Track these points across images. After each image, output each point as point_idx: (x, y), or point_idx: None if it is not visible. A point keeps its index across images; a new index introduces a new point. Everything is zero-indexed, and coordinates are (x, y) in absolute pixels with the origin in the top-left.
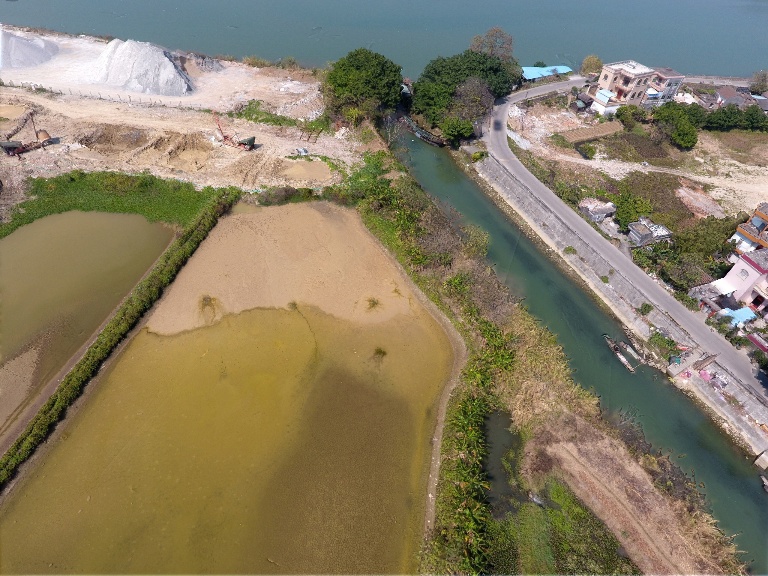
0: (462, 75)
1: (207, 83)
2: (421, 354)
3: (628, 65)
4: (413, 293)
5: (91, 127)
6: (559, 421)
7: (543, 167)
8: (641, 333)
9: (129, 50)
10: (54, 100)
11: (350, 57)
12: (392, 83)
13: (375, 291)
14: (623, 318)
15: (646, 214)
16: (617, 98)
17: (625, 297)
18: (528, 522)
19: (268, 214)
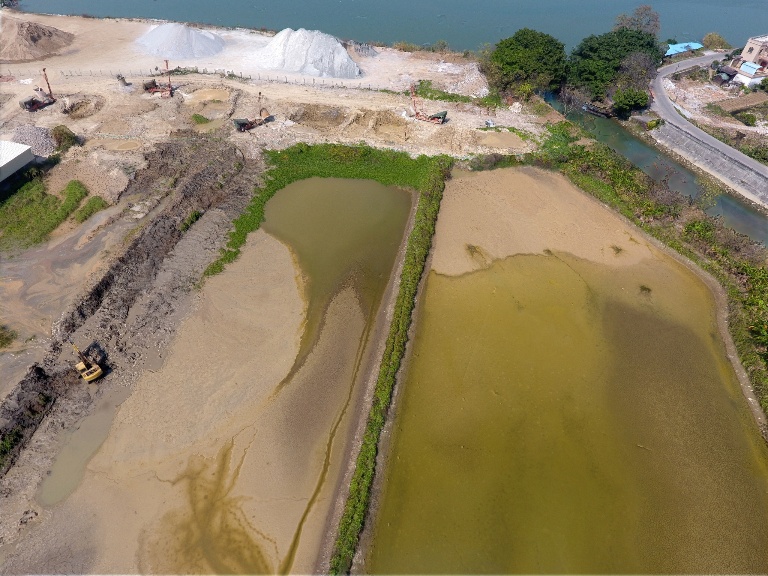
0: (622, 51)
1: (370, 67)
2: (682, 290)
3: None
4: (648, 241)
5: (294, 106)
6: None
7: None
8: None
9: (302, 38)
10: (247, 84)
11: (518, 37)
12: (559, 60)
13: (614, 240)
14: None
15: None
16: (760, 70)
17: None
18: None
19: (485, 177)
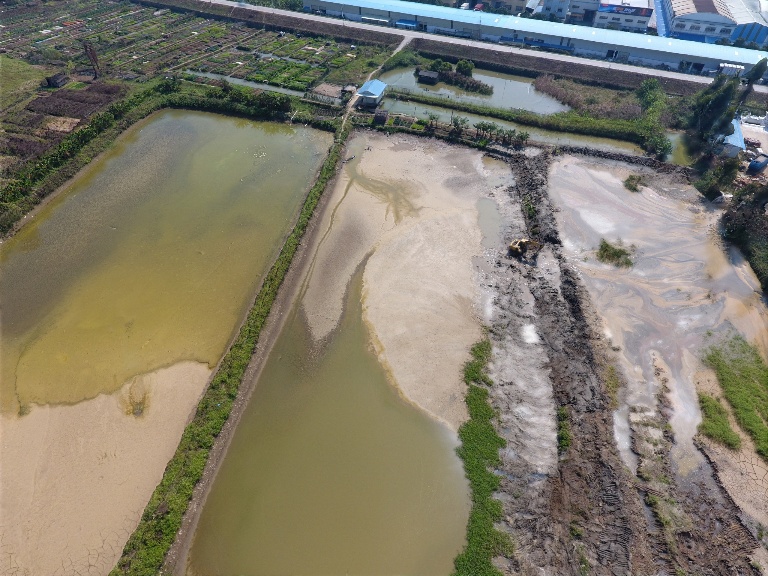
0: None
1: None
2: None
3: None
4: None
5: None
6: None
7: None
8: None
9: None
10: None
11: None
12: None
13: None
14: None
15: None
16: None
17: None
18: None
19: None
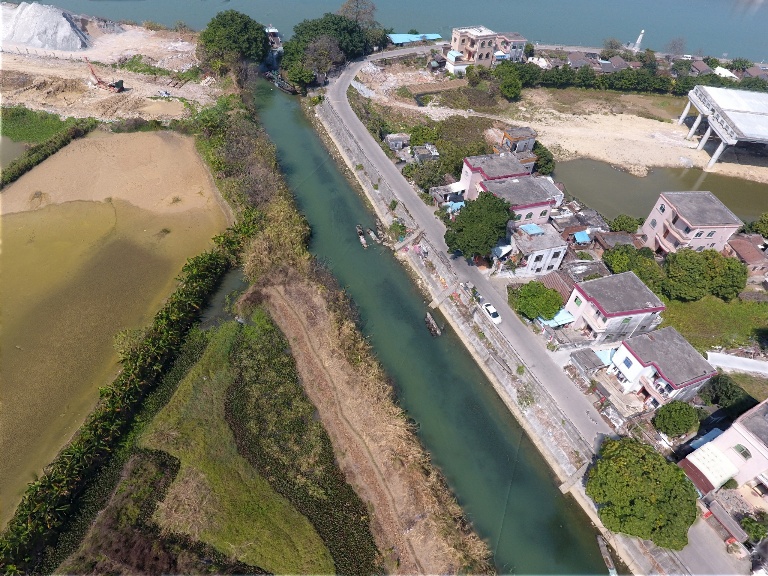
0: (318, 34)
1: (104, 42)
2: (199, 233)
3: (476, 29)
4: (214, 194)
5: None
6: (277, 271)
7: (376, 111)
8: (387, 223)
9: (33, 11)
10: None
11: (218, 17)
12: (254, 39)
13: (182, 192)
14: (380, 214)
15: (432, 141)
16: (468, 59)
17: (385, 199)
18: (222, 330)
19: (116, 138)
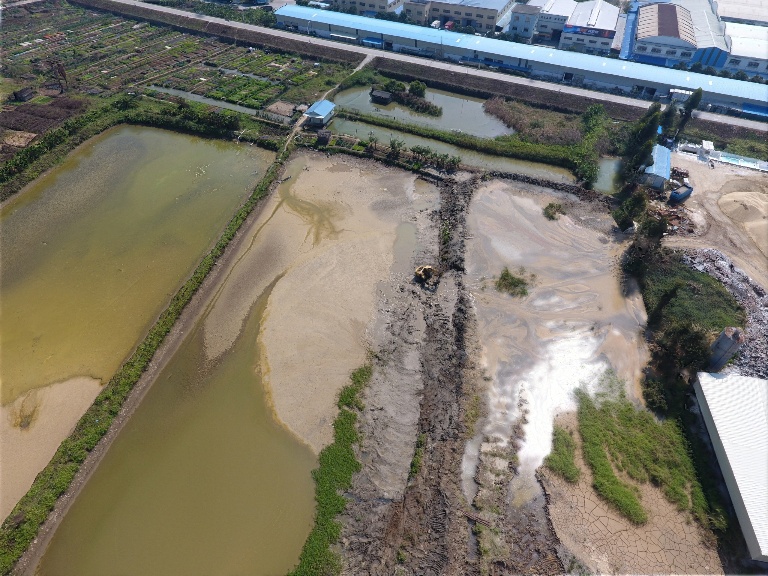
0: None
1: None
2: None
3: None
4: None
5: None
6: None
7: None
8: None
9: None
10: None
11: None
12: None
13: None
14: None
15: None
16: None
17: None
18: None
19: None
